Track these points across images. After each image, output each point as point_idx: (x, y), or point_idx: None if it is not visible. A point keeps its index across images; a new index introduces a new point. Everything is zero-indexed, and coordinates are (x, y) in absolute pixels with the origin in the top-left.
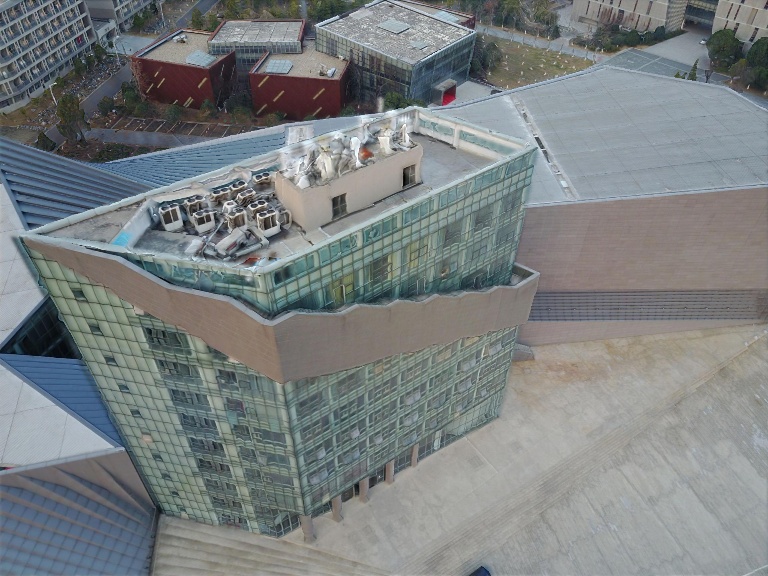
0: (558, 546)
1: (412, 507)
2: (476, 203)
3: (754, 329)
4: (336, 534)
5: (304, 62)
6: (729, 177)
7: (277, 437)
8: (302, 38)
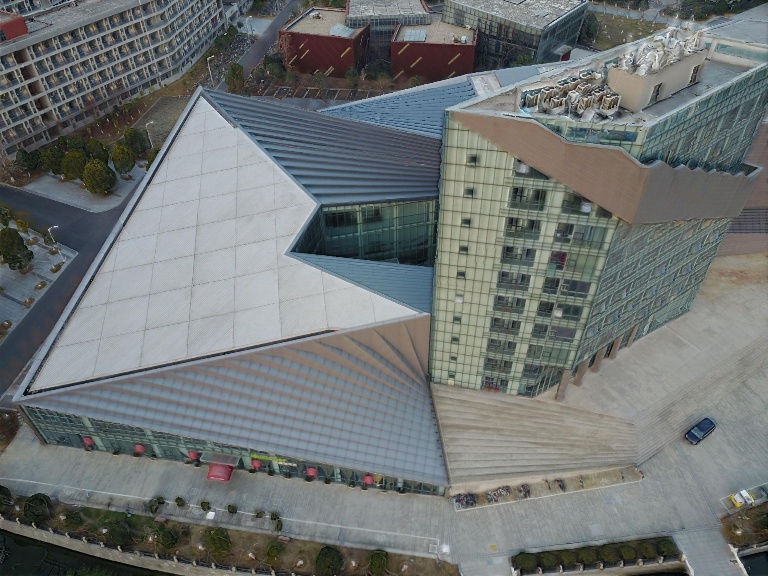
0: (764, 405)
1: (636, 376)
2: (748, 95)
3: None
4: (580, 395)
5: (435, 32)
6: None
7: (582, 288)
8: None
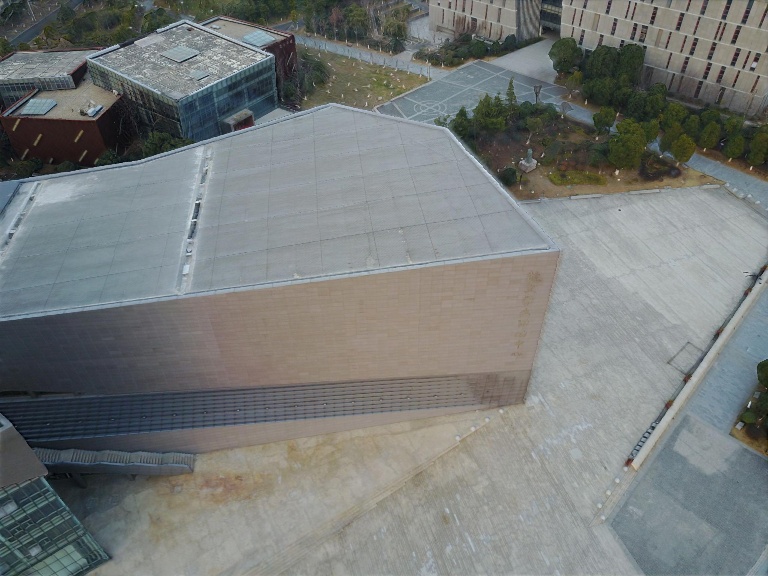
0: None
1: None
2: None
3: (475, 417)
4: None
5: (72, 99)
6: (376, 255)
7: None
8: (83, 70)
